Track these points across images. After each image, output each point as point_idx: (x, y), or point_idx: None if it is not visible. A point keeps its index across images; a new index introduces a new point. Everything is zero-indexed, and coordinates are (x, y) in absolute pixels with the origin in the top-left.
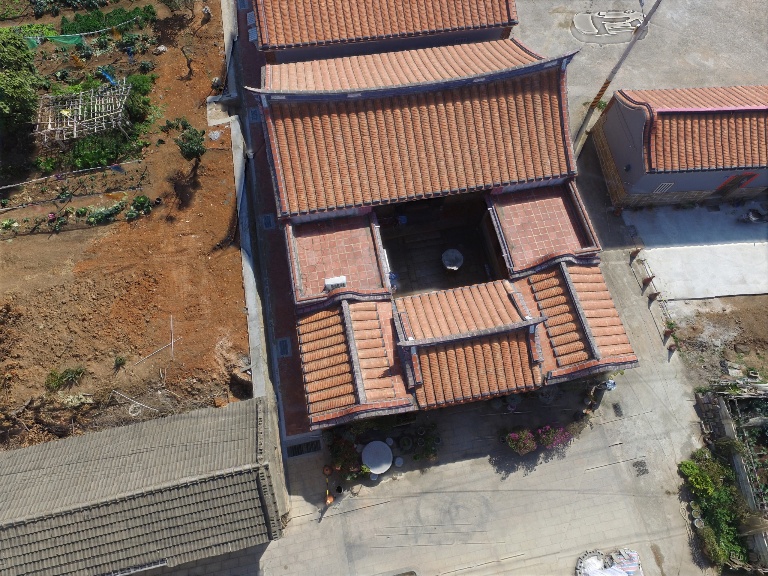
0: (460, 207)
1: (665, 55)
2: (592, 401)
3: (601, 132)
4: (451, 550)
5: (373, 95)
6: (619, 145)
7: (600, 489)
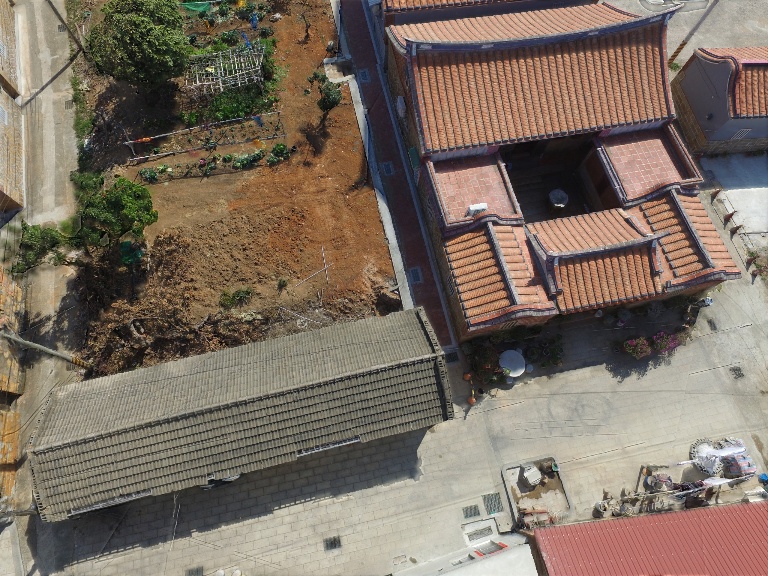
0: (557, 155)
1: (726, 22)
2: (690, 317)
3: (678, 88)
4: (581, 440)
5: (503, 46)
6: (700, 97)
7: (704, 389)
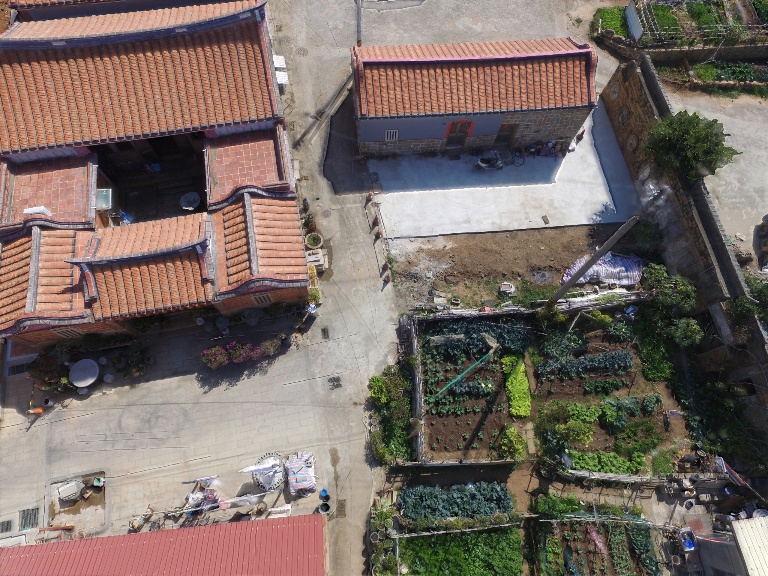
0: None
1: (437, 20)
2: (300, 325)
3: None
4: (143, 453)
5: (79, 43)
6: (355, 97)
7: (293, 401)
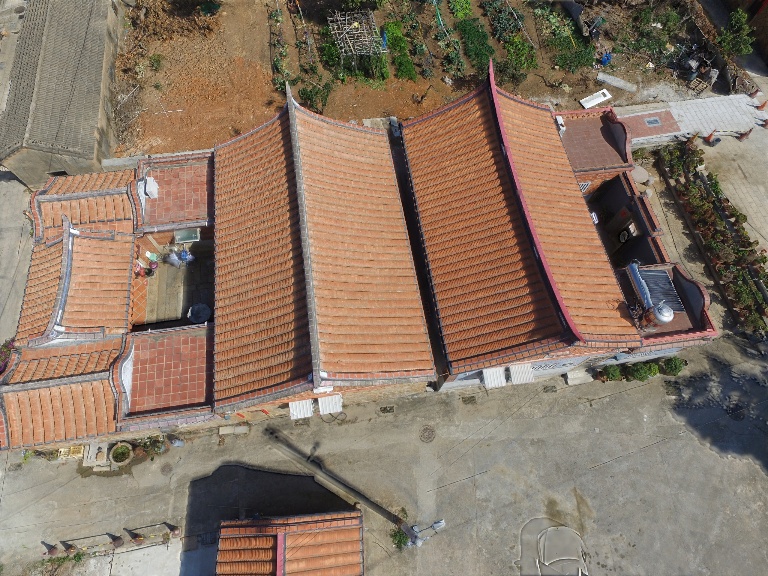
0: None
1: None
2: None
3: None
4: None
5: None
6: None
7: None
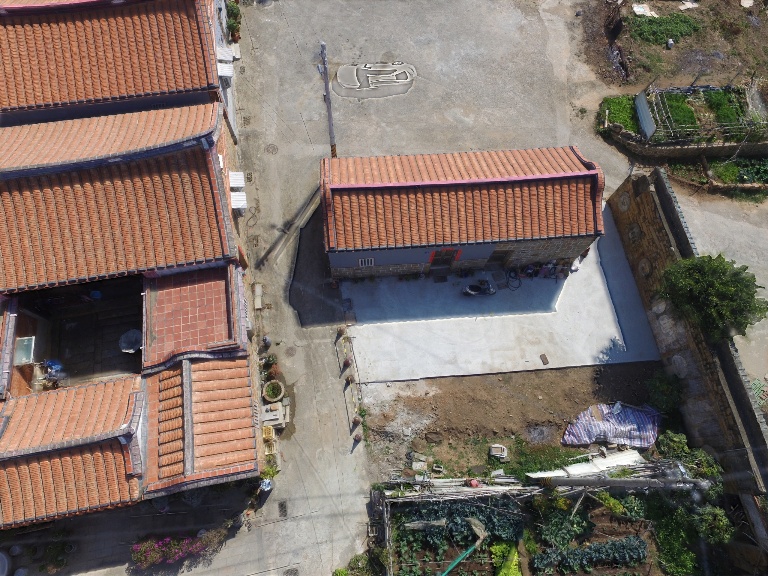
0: None
1: (424, 111)
2: (252, 501)
3: None
4: None
5: None
6: None
7: None
